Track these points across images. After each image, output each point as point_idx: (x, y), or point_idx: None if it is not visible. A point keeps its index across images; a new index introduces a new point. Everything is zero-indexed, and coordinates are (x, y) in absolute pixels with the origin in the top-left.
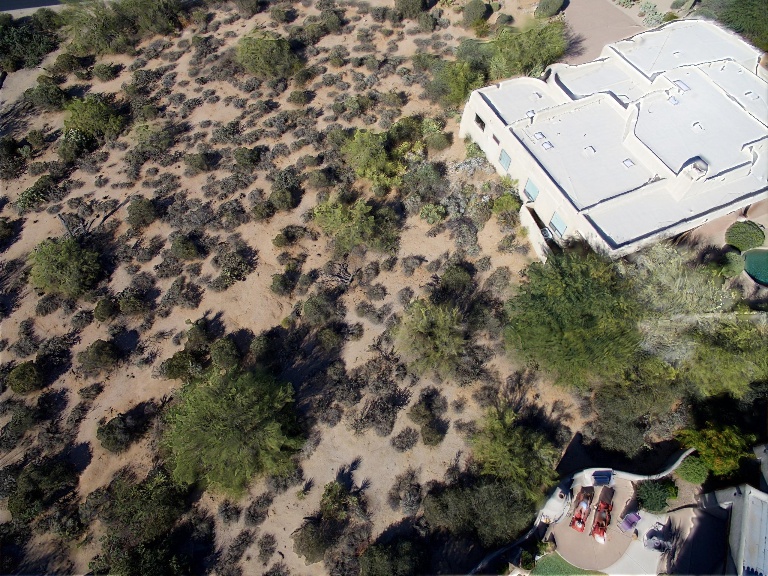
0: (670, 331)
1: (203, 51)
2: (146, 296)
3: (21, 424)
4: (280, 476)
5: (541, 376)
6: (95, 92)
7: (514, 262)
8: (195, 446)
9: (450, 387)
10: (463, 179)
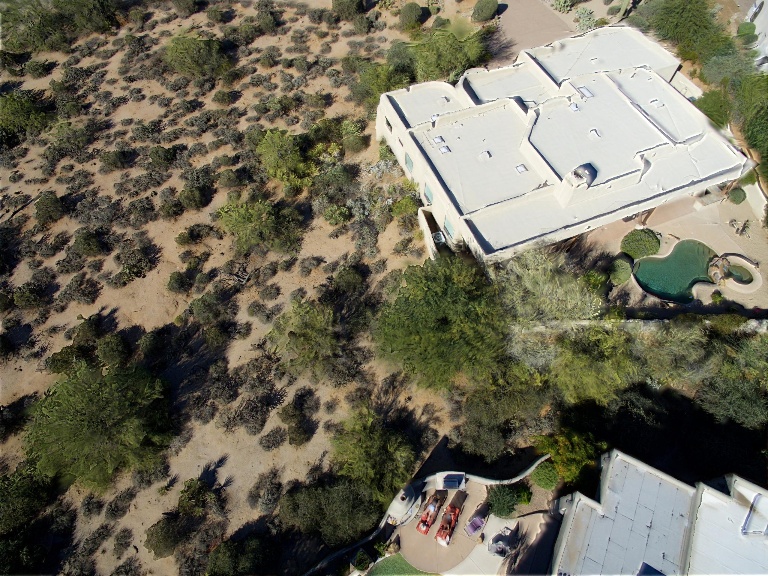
0: (545, 337)
1: (135, 50)
2: (45, 291)
3: None
4: (145, 471)
5: (416, 379)
6: (26, 88)
7: None
8: (55, 439)
9: (325, 388)
10: (374, 181)
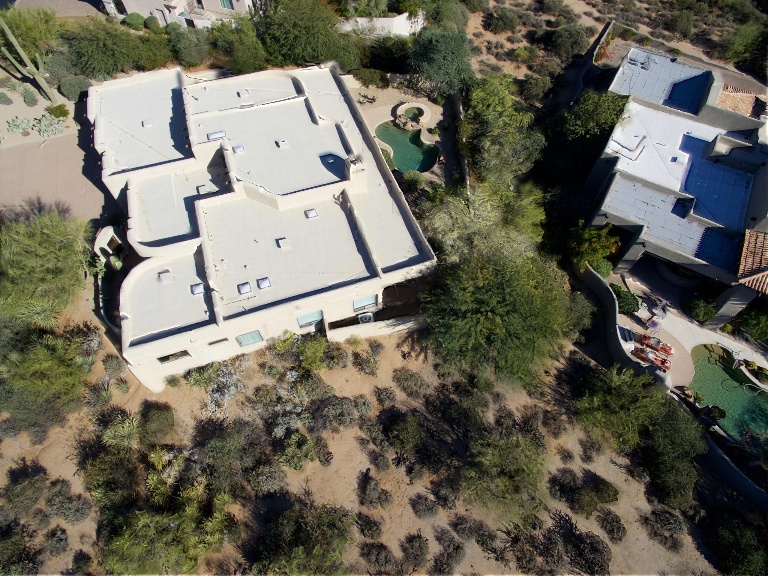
0: None
1: None
2: None
3: None
4: None
5: None
6: None
7: (390, 362)
8: None
9: (547, 462)
10: (241, 400)
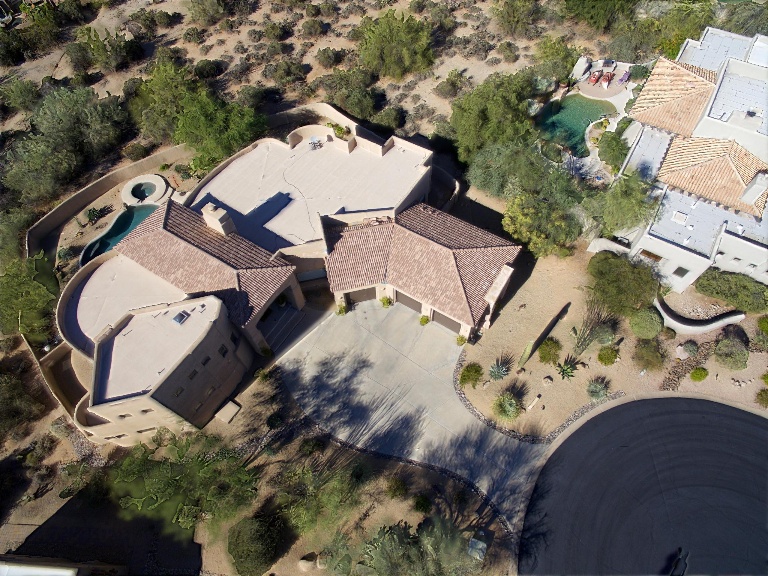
0: None
1: None
2: None
3: (275, 47)
4: None
5: (577, 38)
6: None
7: None
8: None
9: (521, 42)
10: None
